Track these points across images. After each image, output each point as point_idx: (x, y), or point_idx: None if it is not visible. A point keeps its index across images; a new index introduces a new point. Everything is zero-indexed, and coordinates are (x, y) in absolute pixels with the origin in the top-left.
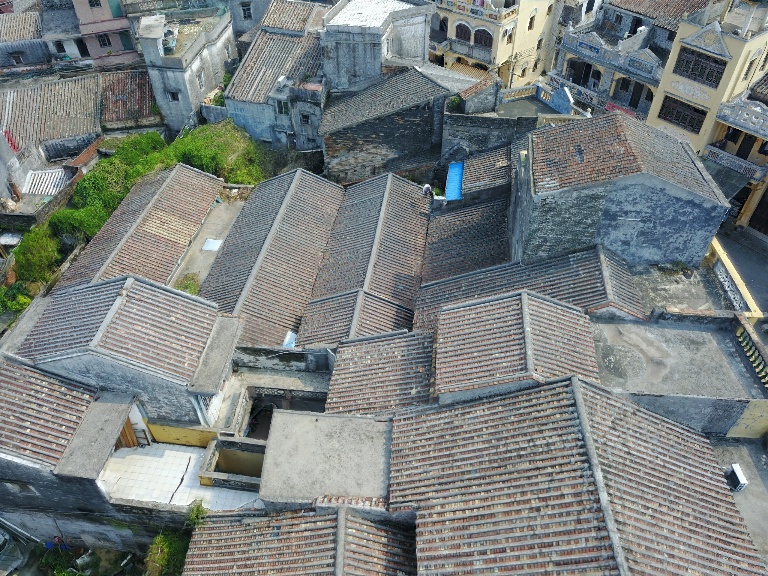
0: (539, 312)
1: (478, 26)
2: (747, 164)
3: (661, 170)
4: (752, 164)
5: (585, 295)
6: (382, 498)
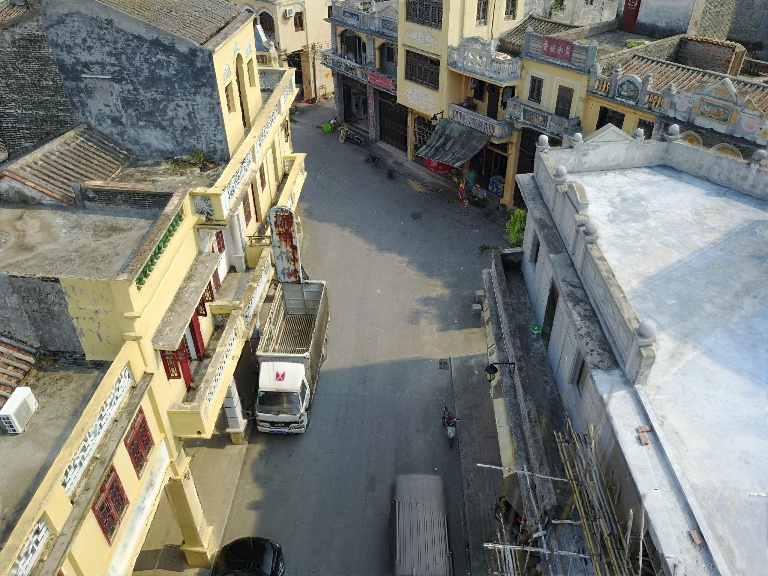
0: None
1: (260, 9)
2: (485, 119)
3: (123, 2)
4: (490, 119)
5: None
6: None
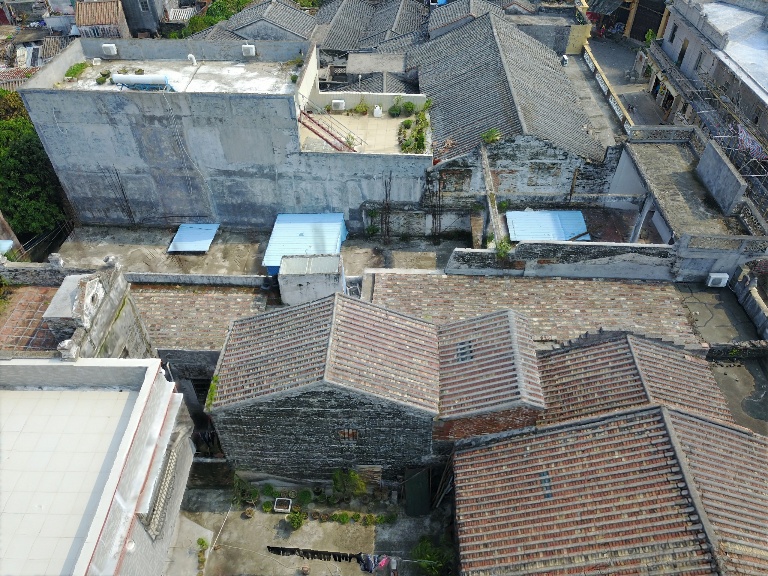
0: (479, 3)
1: None
2: None
3: None
4: None
5: (503, 3)
6: (403, 71)
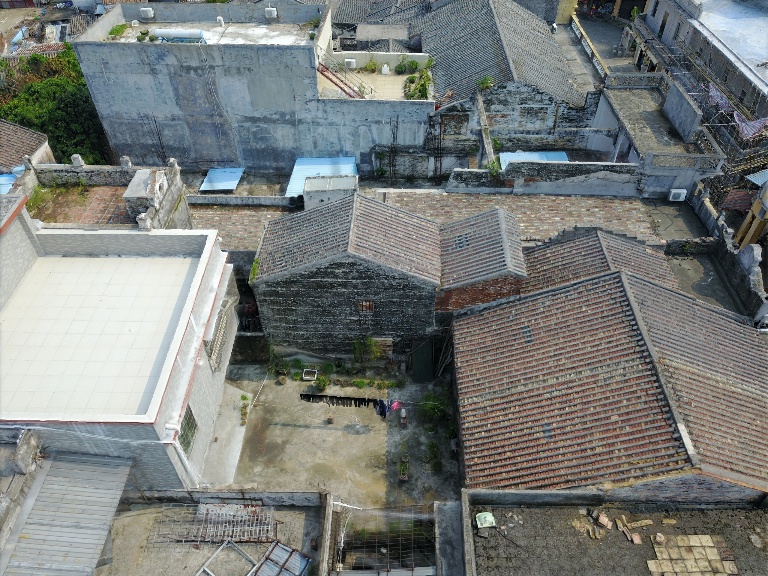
0: None
1: None
2: None
3: None
4: None
5: None
6: None
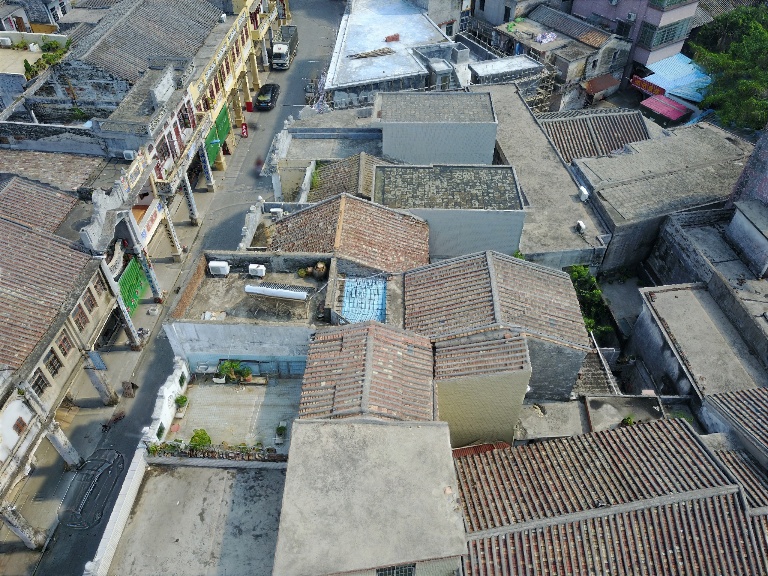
0: None
1: None
2: None
3: None
4: None
5: None
6: None
